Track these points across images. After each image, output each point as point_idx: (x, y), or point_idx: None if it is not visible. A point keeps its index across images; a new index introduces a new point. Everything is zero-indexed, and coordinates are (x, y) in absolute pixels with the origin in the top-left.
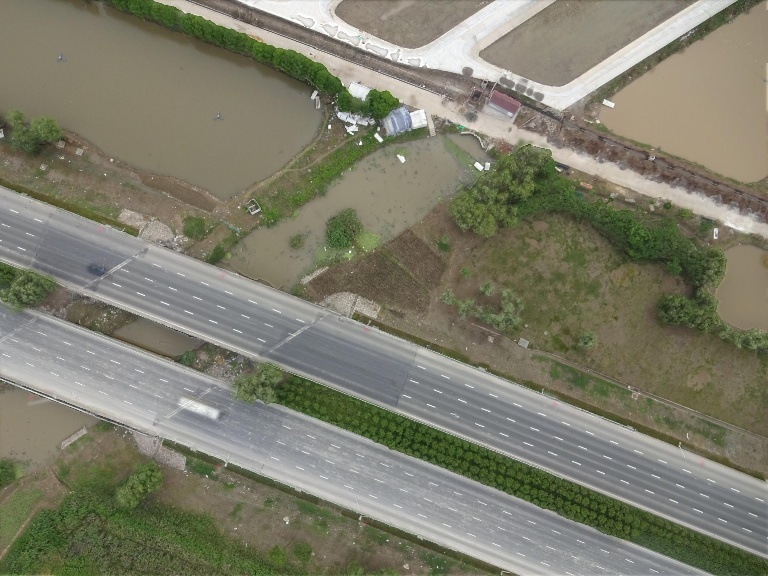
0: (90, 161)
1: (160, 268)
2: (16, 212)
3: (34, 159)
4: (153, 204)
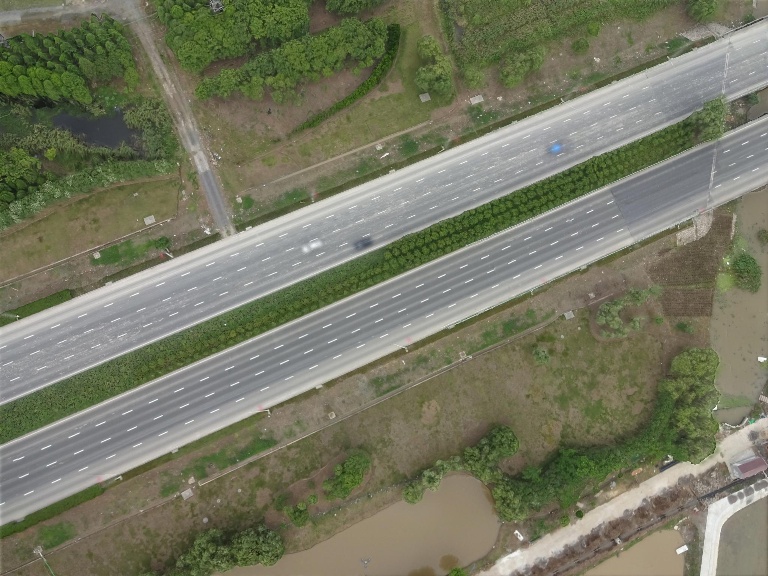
0: None
1: None
2: None
3: None
4: None
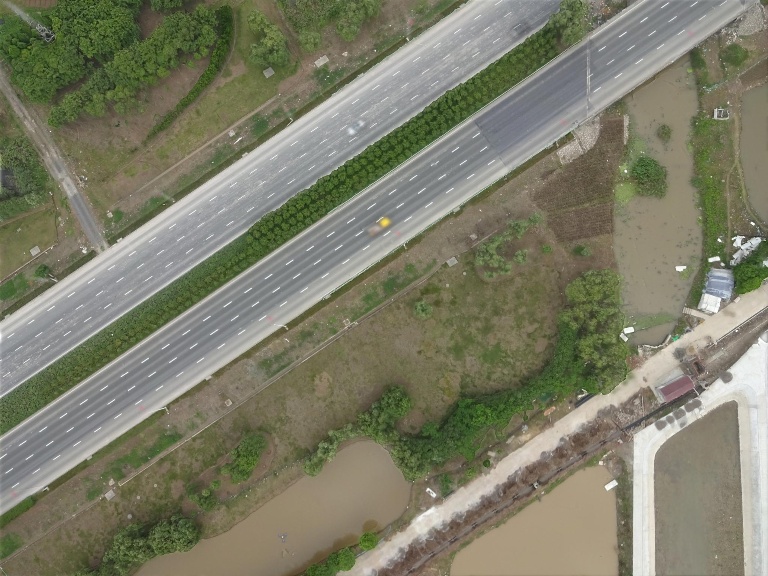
0: None
1: (719, 4)
2: None
3: None
4: None
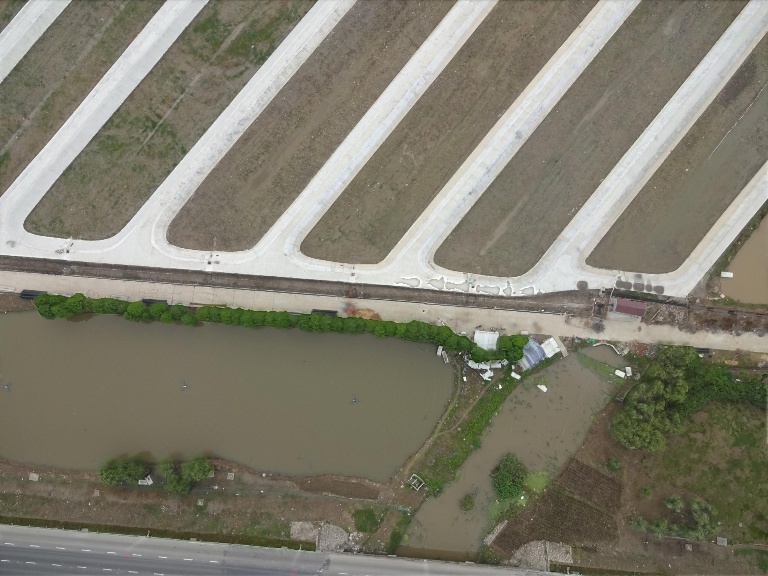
0: (243, 482)
1: (348, 575)
2: (190, 560)
3: (189, 497)
4: (317, 508)
